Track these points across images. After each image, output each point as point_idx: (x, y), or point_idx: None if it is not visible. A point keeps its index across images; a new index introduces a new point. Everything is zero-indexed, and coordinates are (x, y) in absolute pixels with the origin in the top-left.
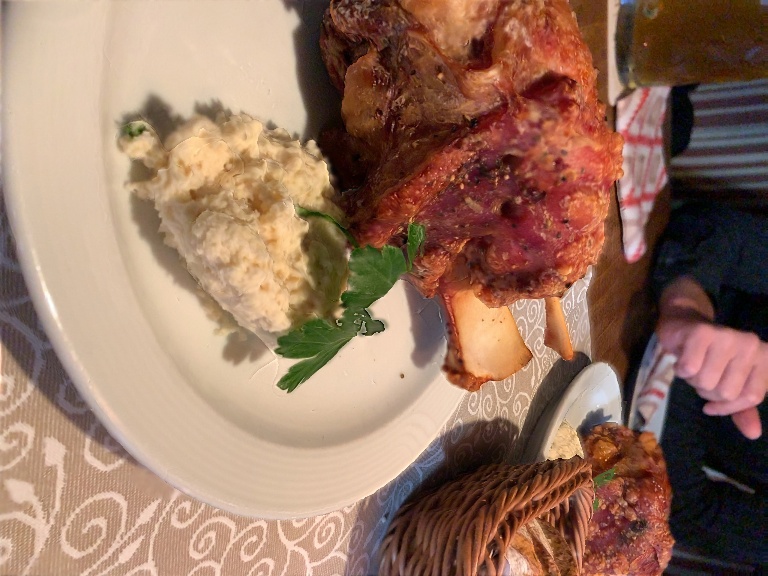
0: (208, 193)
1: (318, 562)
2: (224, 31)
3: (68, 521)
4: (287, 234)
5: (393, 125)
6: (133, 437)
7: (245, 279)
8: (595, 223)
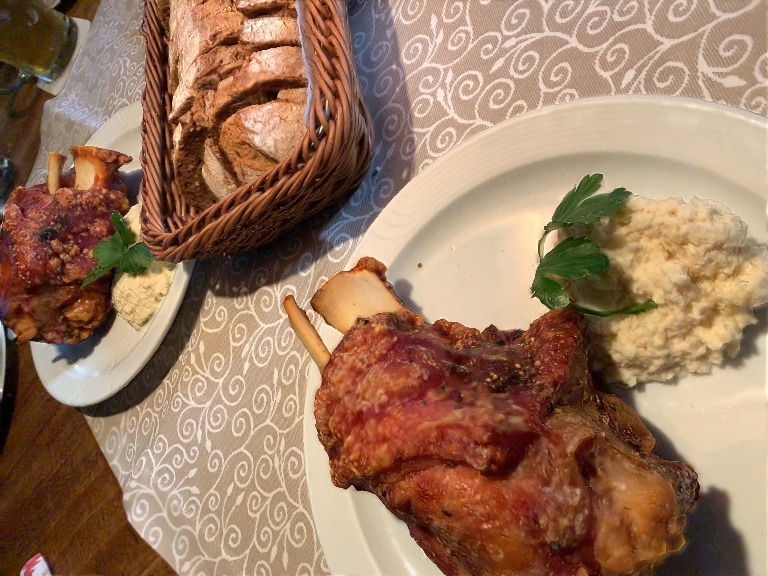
0: (740, 267)
1: (444, 119)
2: (765, 423)
3: (687, 78)
4: (658, 268)
5: (598, 400)
6: (703, 108)
7: (695, 208)
8: (376, 373)
